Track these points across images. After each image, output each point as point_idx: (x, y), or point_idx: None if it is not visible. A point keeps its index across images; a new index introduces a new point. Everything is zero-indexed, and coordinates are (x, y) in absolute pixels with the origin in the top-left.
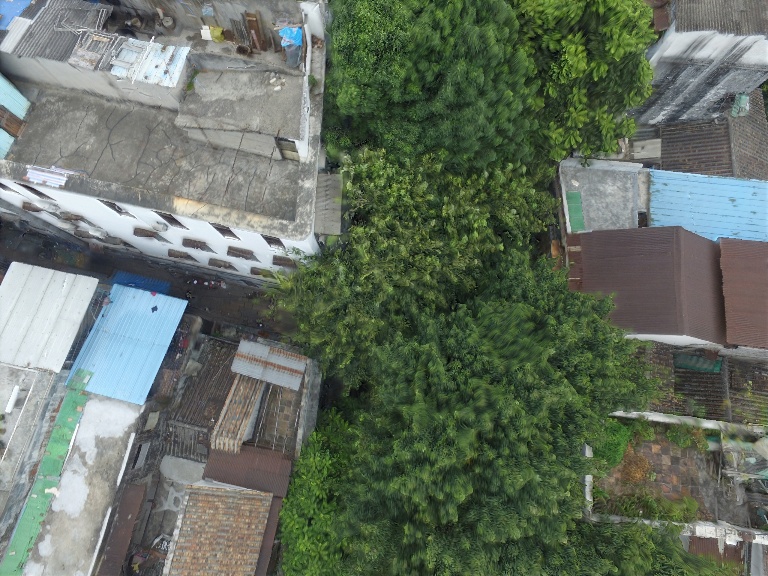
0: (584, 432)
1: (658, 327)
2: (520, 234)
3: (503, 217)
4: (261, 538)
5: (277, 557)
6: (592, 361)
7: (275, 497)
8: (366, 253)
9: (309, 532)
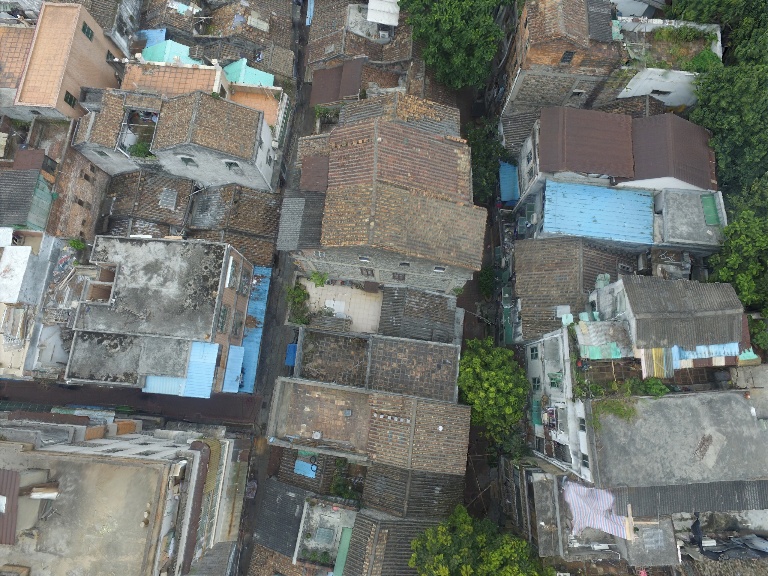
0: None
1: (680, 121)
2: (764, 183)
3: None
4: None
5: None
6: (764, 75)
7: None
8: None
9: None
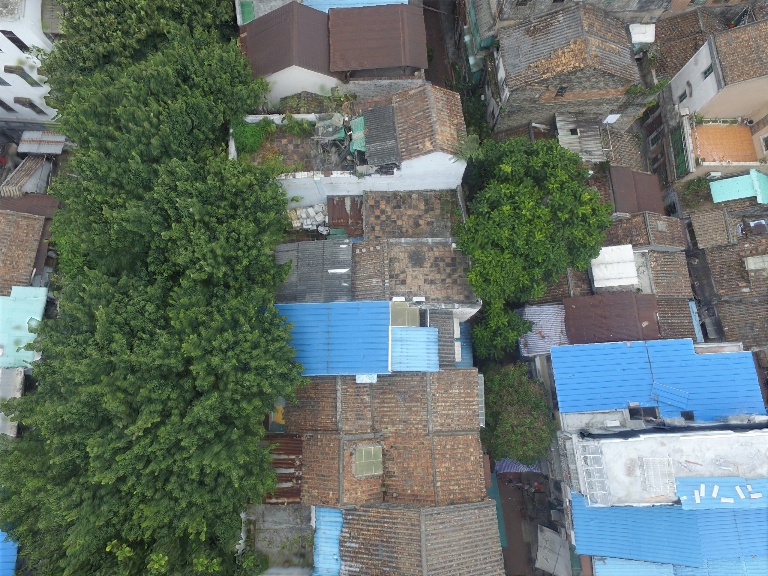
0: (183, 97)
1: (281, 65)
2: (198, 26)
3: (165, 3)
4: (37, 243)
5: (57, 263)
6: None
7: (48, 220)
8: (62, 27)
9: (69, 234)
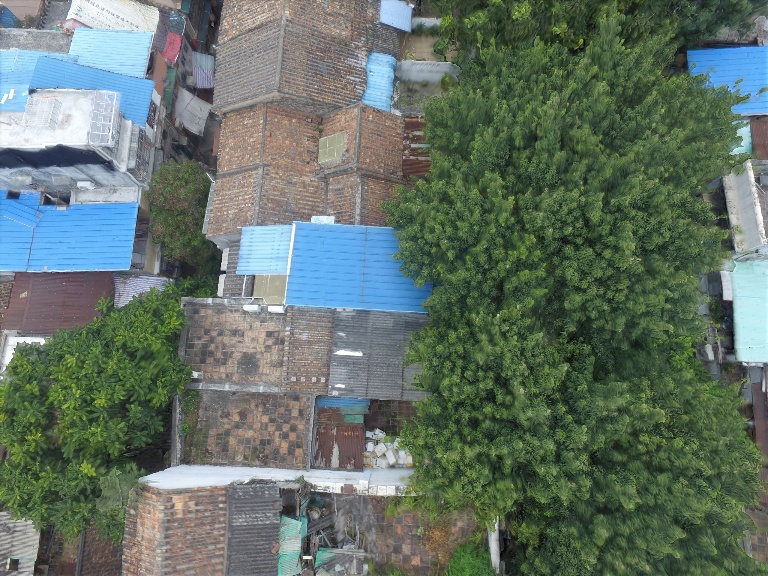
0: None
1: None
2: None
3: None
4: None
5: None
6: None
7: (767, 466)
8: None
9: None
